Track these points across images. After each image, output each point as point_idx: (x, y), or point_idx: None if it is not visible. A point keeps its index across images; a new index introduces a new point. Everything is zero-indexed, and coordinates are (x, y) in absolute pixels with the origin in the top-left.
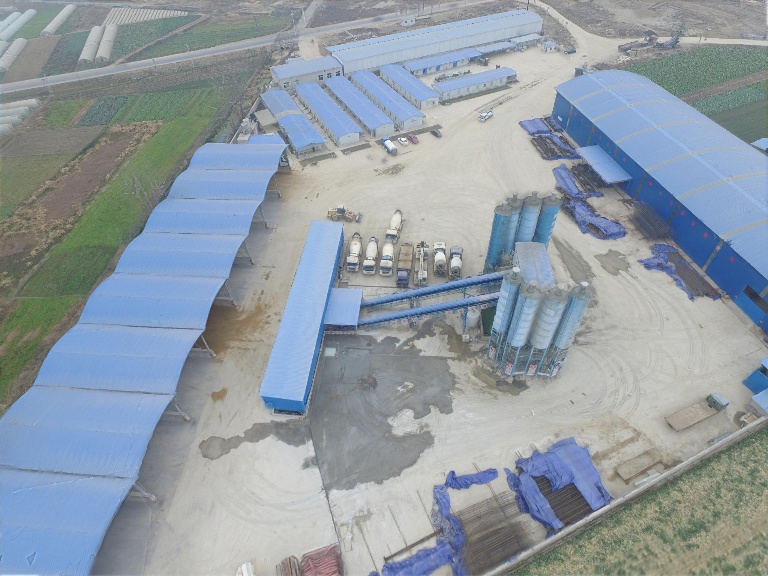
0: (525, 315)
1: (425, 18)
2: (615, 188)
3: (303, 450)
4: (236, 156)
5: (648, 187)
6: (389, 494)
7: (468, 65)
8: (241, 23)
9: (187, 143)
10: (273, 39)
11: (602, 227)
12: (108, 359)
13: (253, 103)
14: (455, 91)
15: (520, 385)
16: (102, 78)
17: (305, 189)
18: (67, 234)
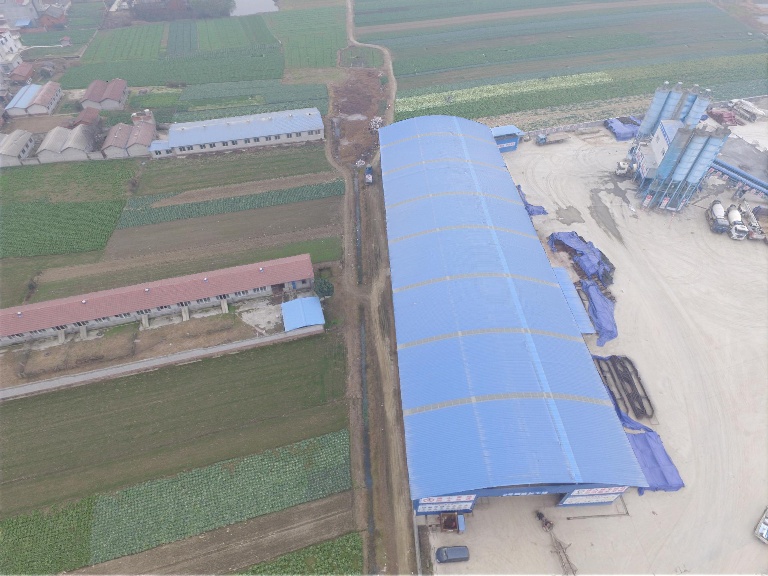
0: None
1: None
2: None
3: None
4: None
5: None
6: None
7: None
8: None
9: None
10: None
11: (576, 237)
12: None
13: None
14: None
15: None
16: None
17: None
18: None
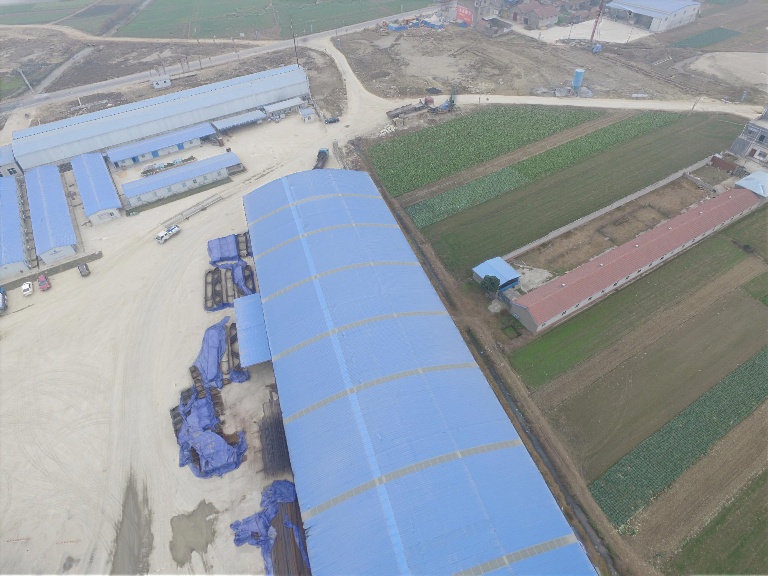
0: None
1: (189, 76)
2: None
3: None
4: None
5: None
6: None
7: (200, 146)
8: None
9: None
10: None
11: (204, 456)
12: None
13: None
14: (148, 194)
15: None
16: None
17: None
18: None
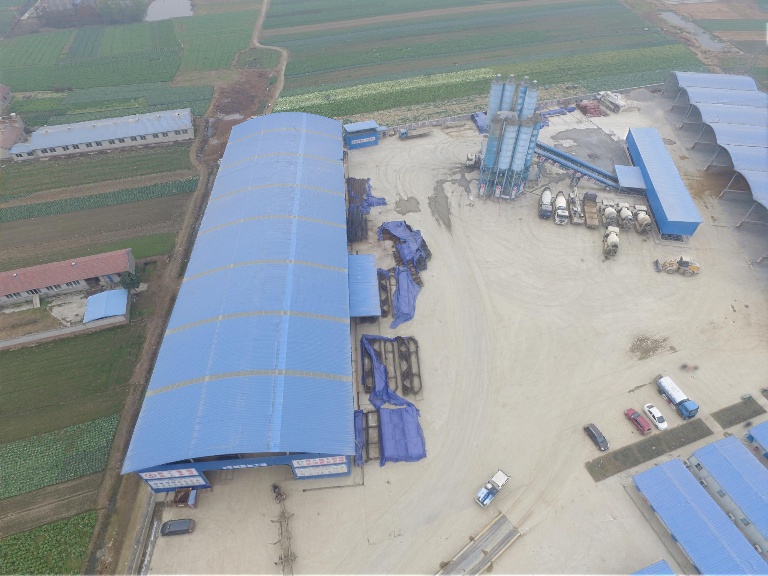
0: None
1: None
2: None
3: None
4: None
5: None
6: (569, 126)
7: None
8: None
9: None
10: None
11: (403, 226)
12: None
13: None
14: None
15: None
16: None
17: (761, 322)
18: None
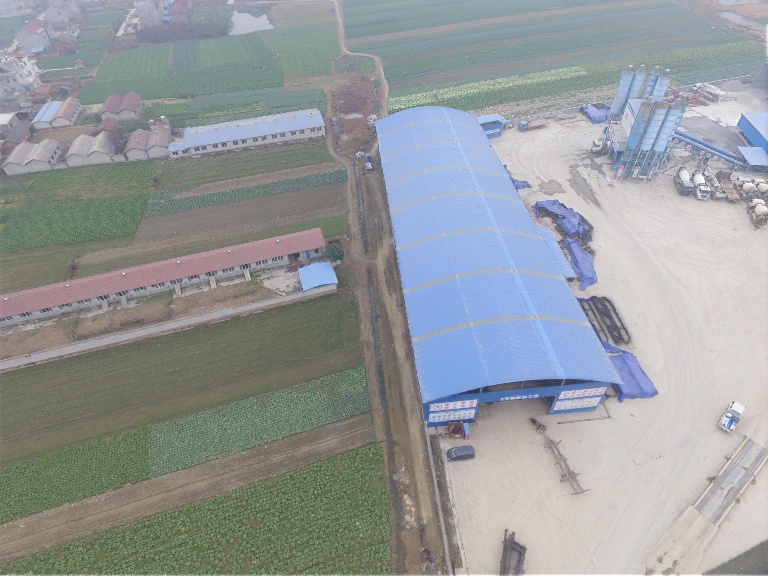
0: None
1: None
2: None
3: None
4: None
5: None
6: None
7: None
8: None
9: None
10: None
11: (557, 204)
12: None
13: None
14: None
15: None
16: None
17: None
18: None
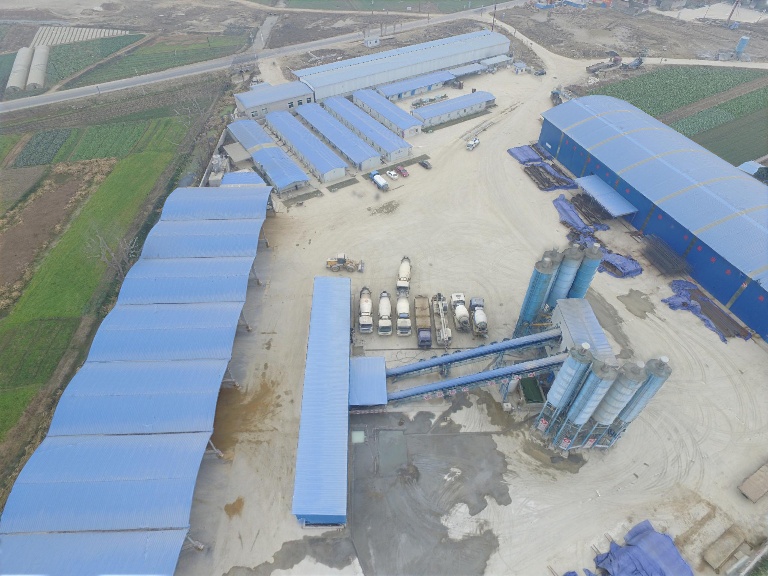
0: (597, 395)
1: (388, 38)
2: (619, 219)
3: (349, 573)
4: (215, 203)
5: (657, 220)
6: None
7: (442, 88)
8: (191, 43)
9: (149, 184)
10: (230, 61)
11: (619, 265)
12: (95, 487)
13: (219, 135)
14: (436, 118)
15: (577, 460)
16: (37, 108)
17: (294, 235)
18: (14, 304)
